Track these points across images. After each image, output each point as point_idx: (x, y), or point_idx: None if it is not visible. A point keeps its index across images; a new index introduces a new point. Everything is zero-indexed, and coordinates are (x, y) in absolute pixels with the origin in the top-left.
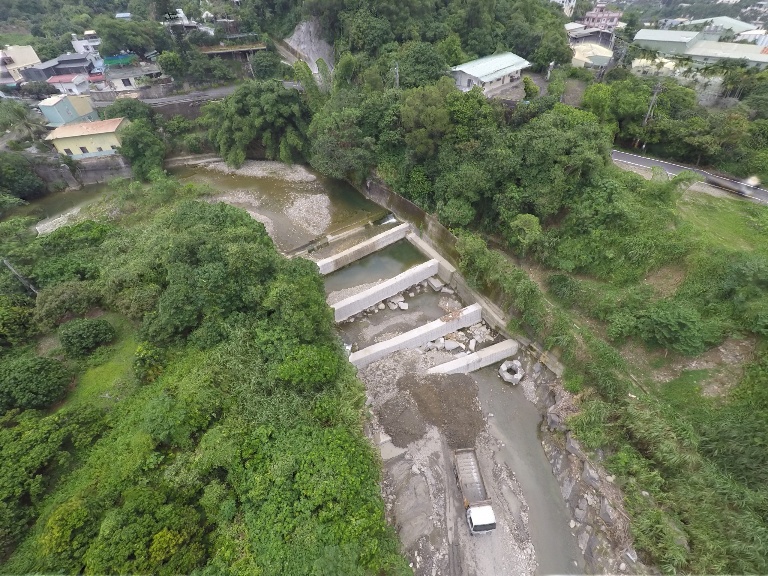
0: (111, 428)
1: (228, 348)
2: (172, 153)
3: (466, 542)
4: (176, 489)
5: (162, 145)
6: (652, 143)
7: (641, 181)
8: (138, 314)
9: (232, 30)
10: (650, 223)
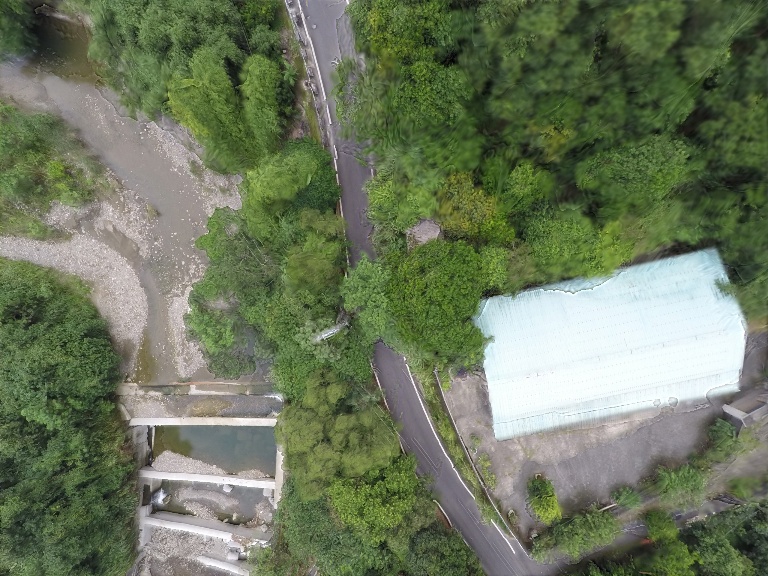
0: None
1: None
2: None
3: None
4: None
5: (7, 21)
6: None
7: None
8: None
9: None
10: None
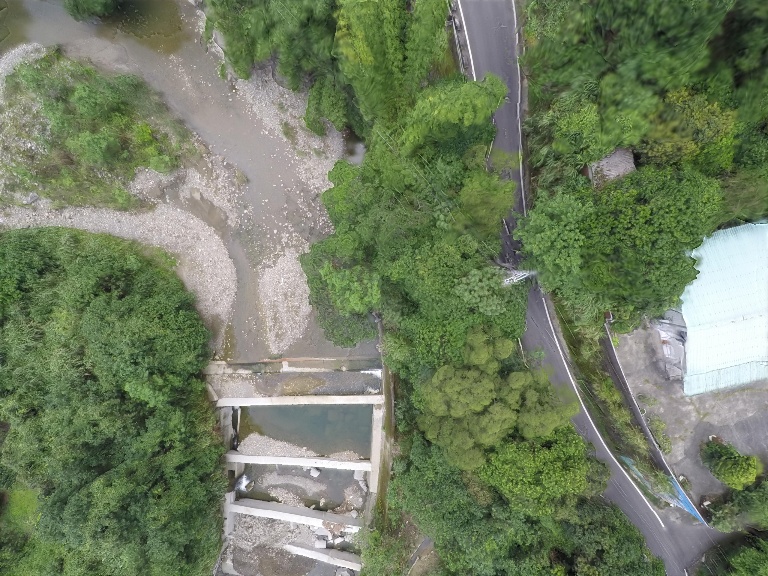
0: (30, 552)
1: None
2: None
3: None
4: None
5: None
6: None
7: None
8: None
9: None
10: None
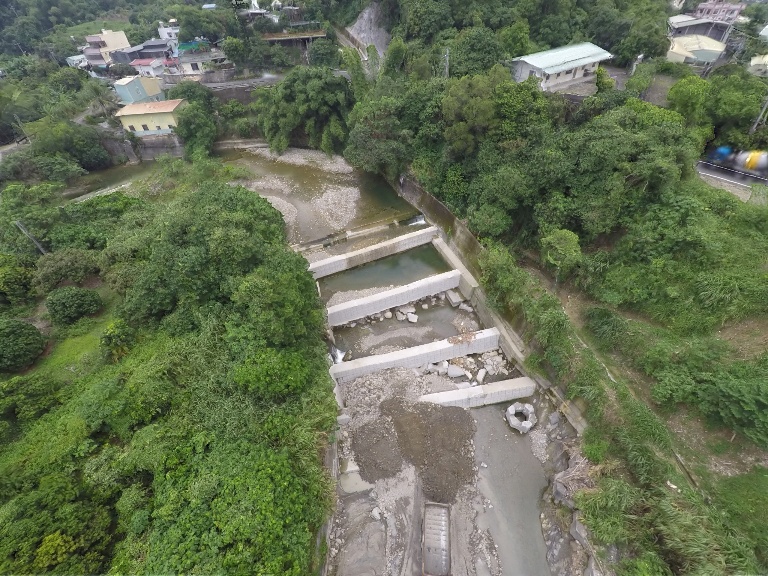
0: (61, 404)
1: (194, 339)
2: (224, 136)
3: None
4: (92, 486)
5: (213, 127)
6: (760, 156)
7: (733, 203)
8: (122, 290)
9: (296, 17)
10: (737, 258)
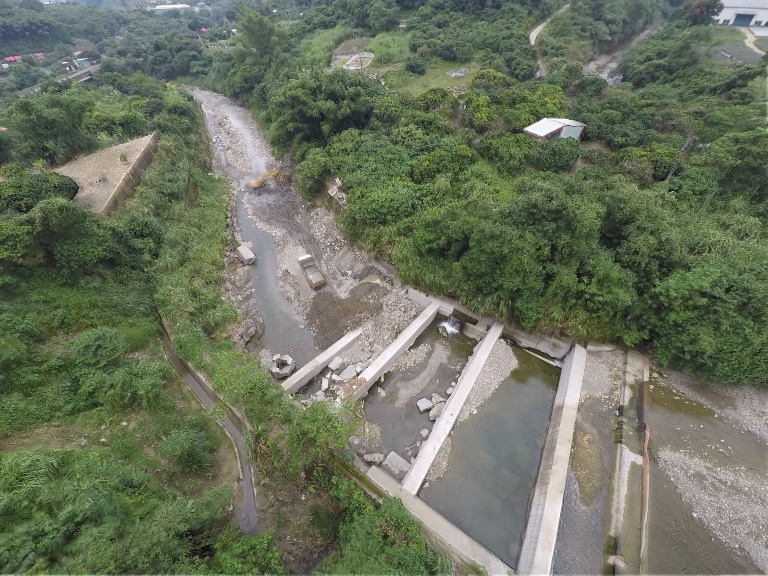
0: None
1: None
2: None
3: None
4: None
5: None
6: None
7: None
8: None
9: None
10: None
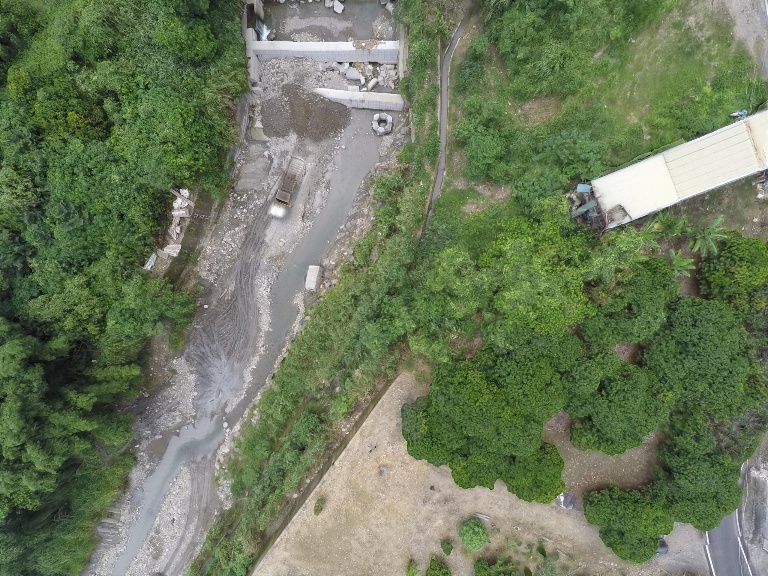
0: (43, 27)
1: None
2: None
3: (276, 204)
4: (84, 92)
5: None
6: None
7: None
8: None
9: None
10: (584, 34)
